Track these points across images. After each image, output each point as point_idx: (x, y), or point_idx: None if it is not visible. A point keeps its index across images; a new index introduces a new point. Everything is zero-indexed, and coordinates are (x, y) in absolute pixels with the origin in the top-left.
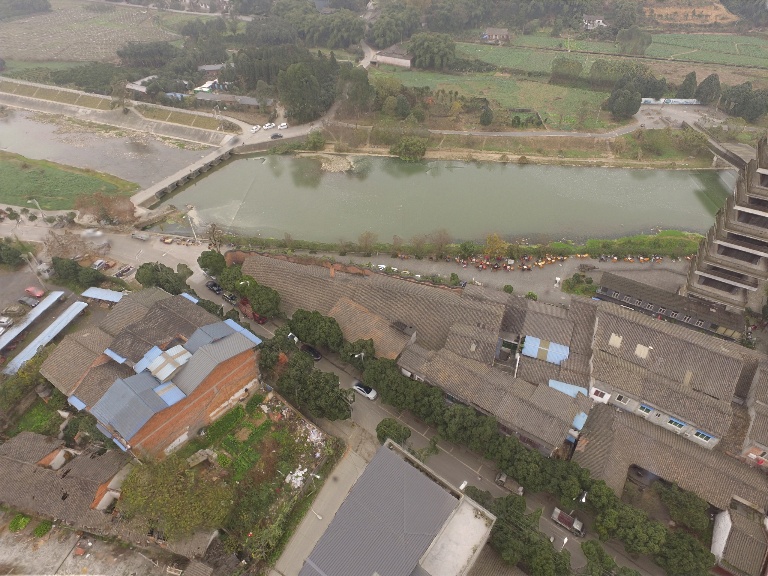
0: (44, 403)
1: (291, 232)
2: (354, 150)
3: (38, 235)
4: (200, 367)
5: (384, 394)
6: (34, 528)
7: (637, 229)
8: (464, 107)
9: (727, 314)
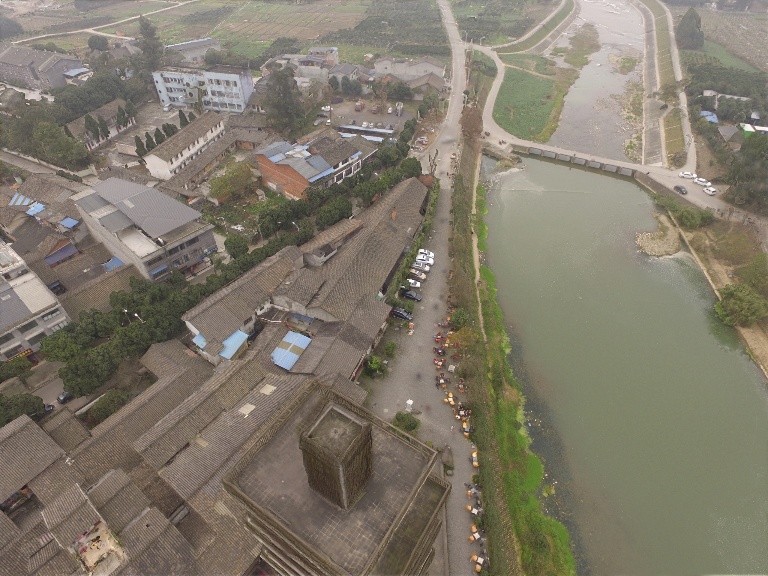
0: None
1: (500, 221)
2: (705, 256)
3: (453, 116)
4: None
5: None
6: None
7: None
8: None
9: None
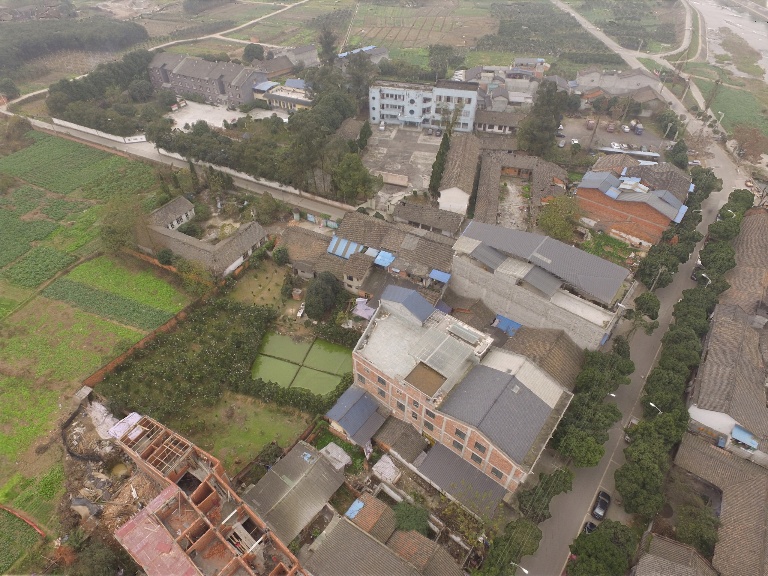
0: None
1: None
2: None
3: None
4: (638, 197)
5: (681, 302)
6: (526, 193)
7: None
8: None
9: None
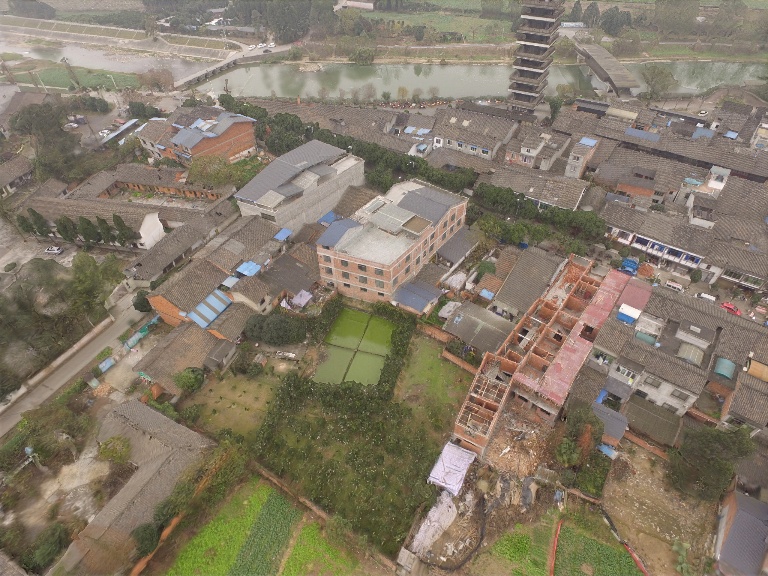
0: (138, 160)
1: None
2: (323, 59)
3: None
4: (224, 125)
5: None
6: (145, 195)
7: (507, 95)
8: (407, 31)
9: (528, 115)
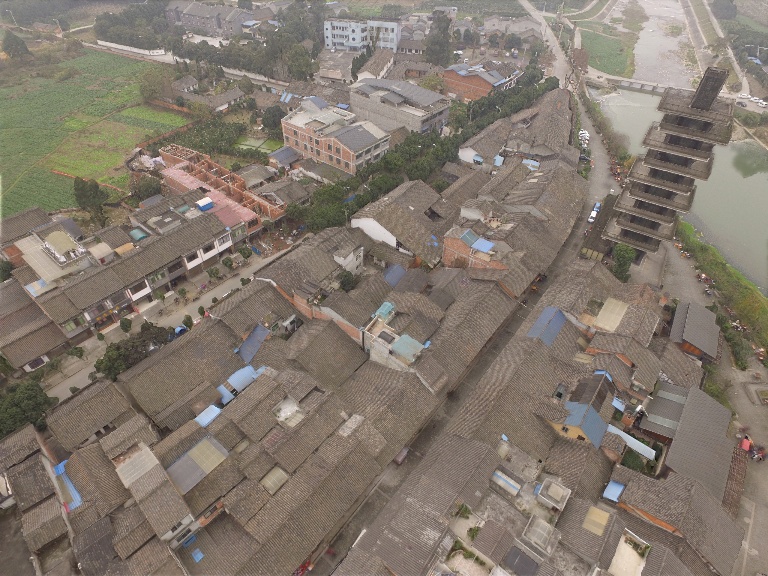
0: None
1: (617, 121)
2: (765, 140)
3: None
4: None
5: None
6: None
7: (767, 287)
8: None
9: (603, 244)
